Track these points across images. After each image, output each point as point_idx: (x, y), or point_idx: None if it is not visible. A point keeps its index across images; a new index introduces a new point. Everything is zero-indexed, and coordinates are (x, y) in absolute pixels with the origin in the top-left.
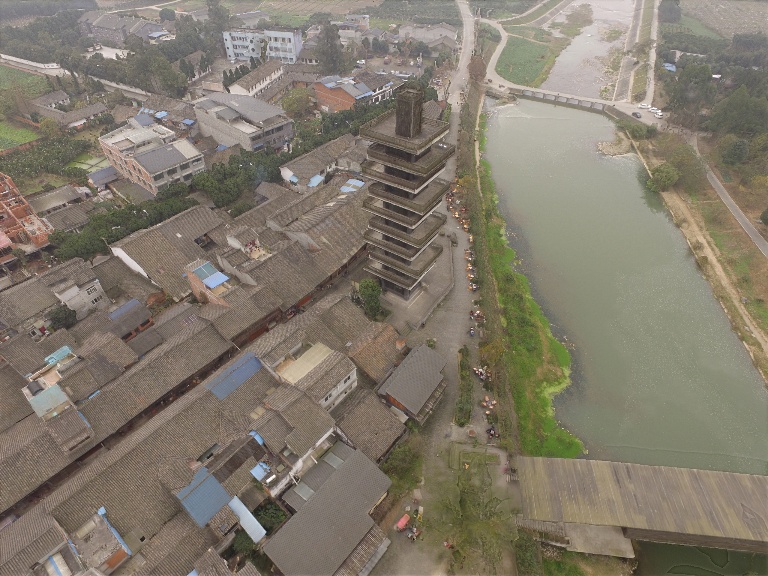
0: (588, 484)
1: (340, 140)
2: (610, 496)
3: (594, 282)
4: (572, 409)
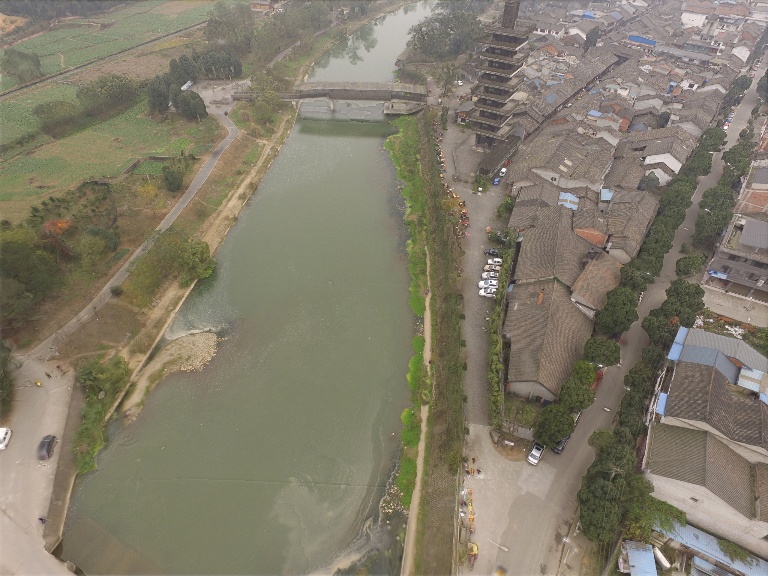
0: None
1: None
2: None
3: (347, 177)
4: (390, 131)
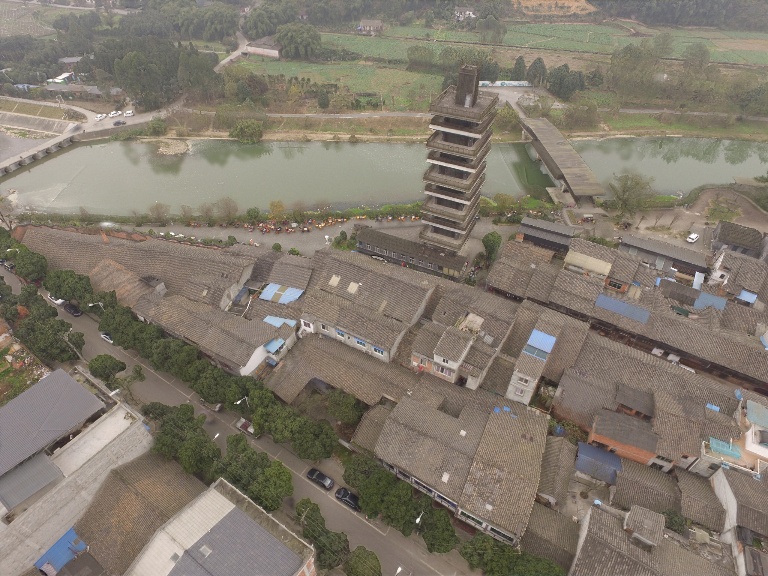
0: (577, 175)
1: (171, 300)
2: (578, 170)
3: (383, 179)
4: None
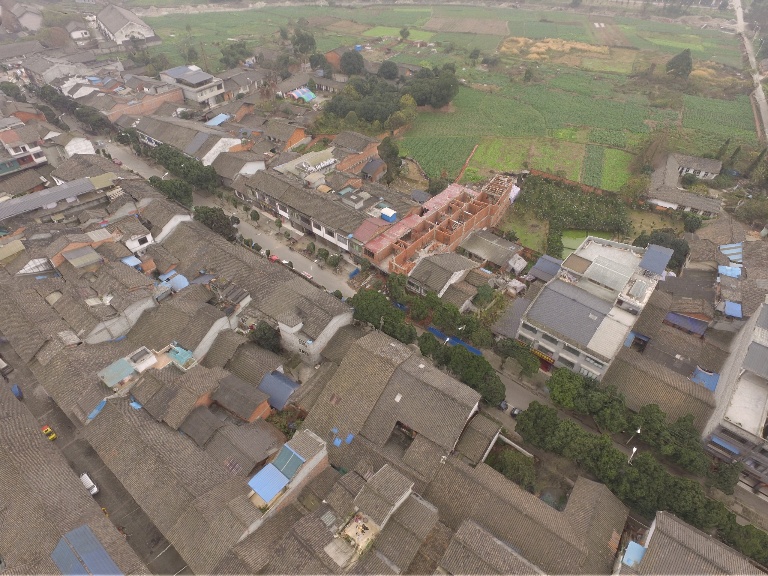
0: None
1: None
2: None
3: None
4: None
